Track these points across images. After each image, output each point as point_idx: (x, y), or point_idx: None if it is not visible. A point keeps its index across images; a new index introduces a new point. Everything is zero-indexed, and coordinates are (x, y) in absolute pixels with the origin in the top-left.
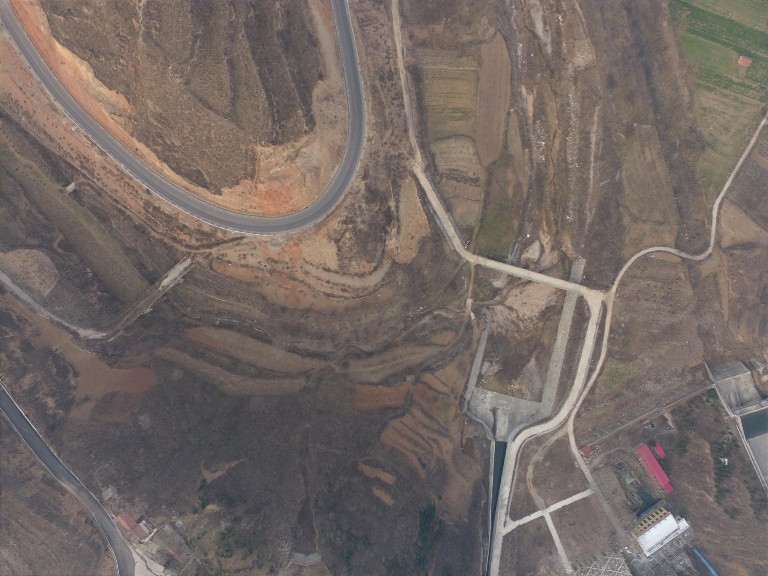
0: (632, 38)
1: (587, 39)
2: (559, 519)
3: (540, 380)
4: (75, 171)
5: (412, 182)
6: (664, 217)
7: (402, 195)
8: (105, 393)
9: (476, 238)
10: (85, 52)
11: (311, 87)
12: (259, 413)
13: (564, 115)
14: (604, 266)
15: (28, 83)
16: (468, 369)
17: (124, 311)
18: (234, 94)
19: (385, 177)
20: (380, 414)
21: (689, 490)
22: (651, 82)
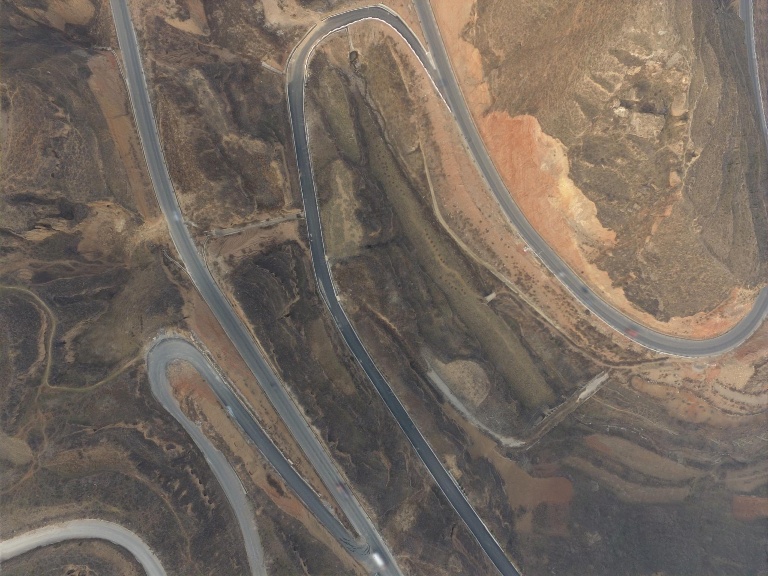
0: None
1: None
2: None
3: None
4: (498, 283)
5: None
6: None
7: None
8: (537, 504)
9: None
10: (599, 195)
11: None
12: (665, 525)
13: None
14: None
15: (487, 204)
16: None
17: None
18: None
19: None
20: (762, 526)
21: None
22: None
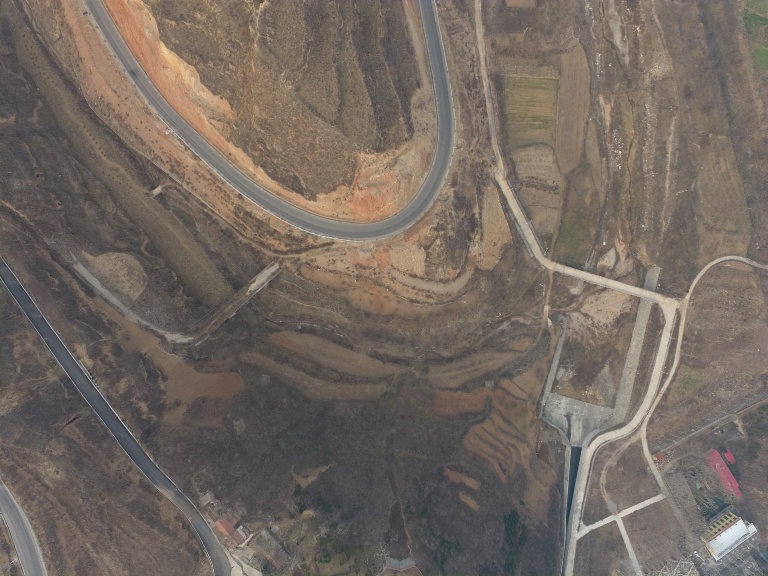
0: (709, 50)
1: (665, 50)
2: (631, 524)
3: (614, 386)
4: (162, 174)
5: (494, 189)
6: (737, 227)
7: (485, 202)
8: (195, 398)
9: (554, 245)
10: (193, 57)
11: (410, 95)
12: (345, 418)
13: (641, 125)
14: (678, 274)
15: (122, 86)
16: (545, 375)
17: (210, 315)
18: (341, 101)
19: (471, 184)
20: (461, 419)
21: (759, 495)
22: (727, 94)
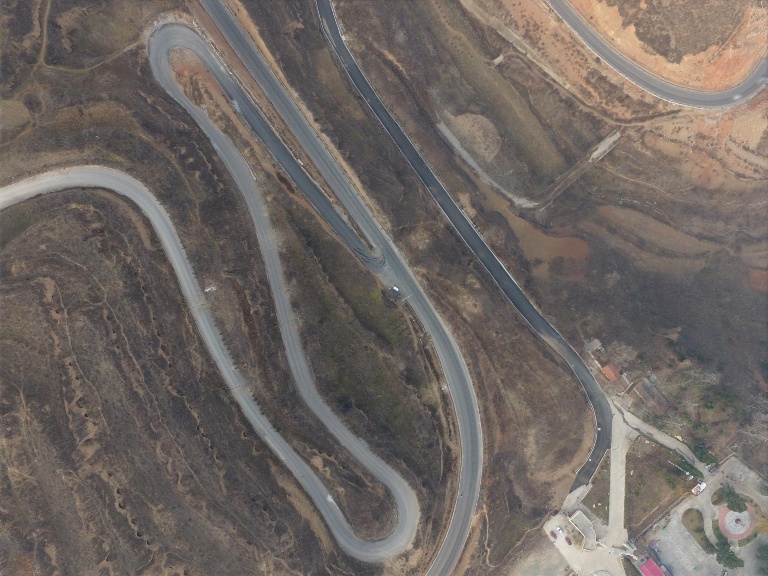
0: None
1: None
2: None
3: None
4: (506, 43)
5: None
6: None
7: None
8: (552, 257)
9: None
10: None
11: None
12: (683, 285)
13: None
14: None
15: None
16: None
17: None
18: None
19: None
20: None
21: None
22: None
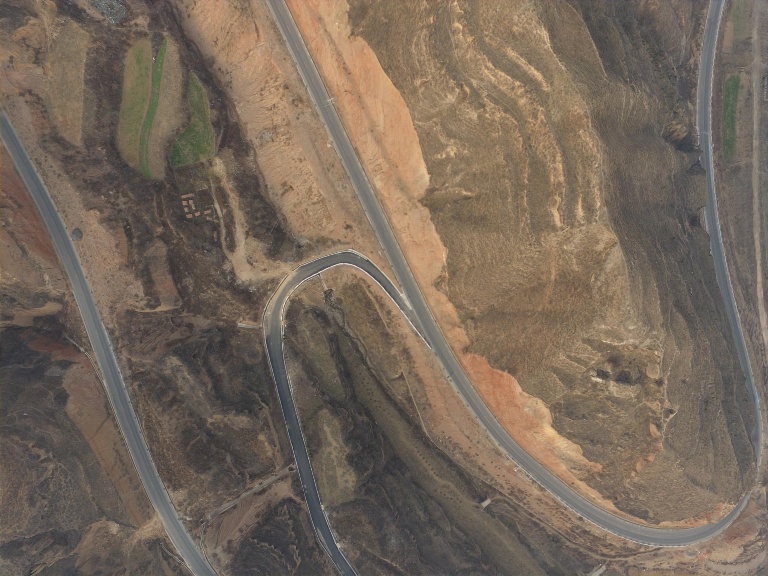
0: None
1: None
2: None
3: None
4: (492, 490)
5: None
6: None
7: None
8: None
9: None
10: (583, 441)
11: (750, 431)
12: None
13: None
14: None
15: (474, 432)
16: None
17: None
18: None
19: None
20: None
21: None
22: None
